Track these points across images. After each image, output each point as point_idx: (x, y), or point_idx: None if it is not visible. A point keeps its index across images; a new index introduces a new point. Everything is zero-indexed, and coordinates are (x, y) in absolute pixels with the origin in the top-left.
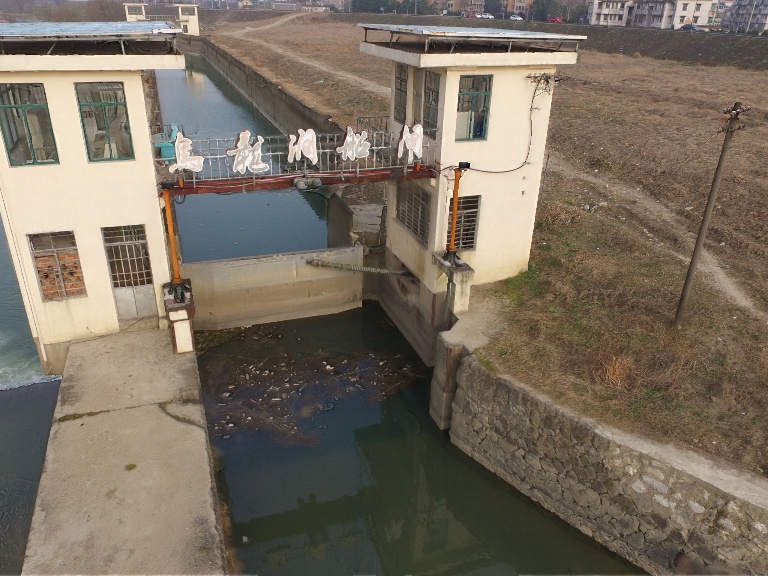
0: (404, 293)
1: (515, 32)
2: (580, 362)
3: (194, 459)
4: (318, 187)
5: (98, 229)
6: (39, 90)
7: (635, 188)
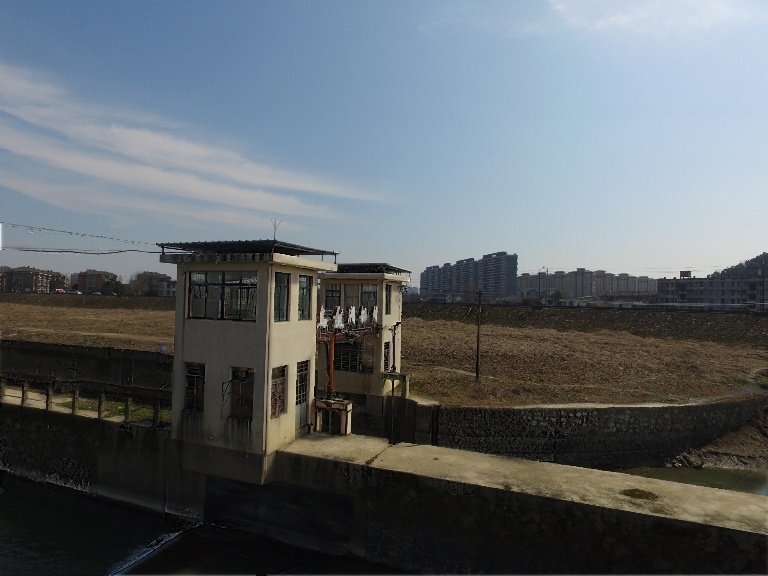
0: None
1: None
2: (476, 396)
3: None
4: None
5: (296, 363)
6: (196, 288)
7: None
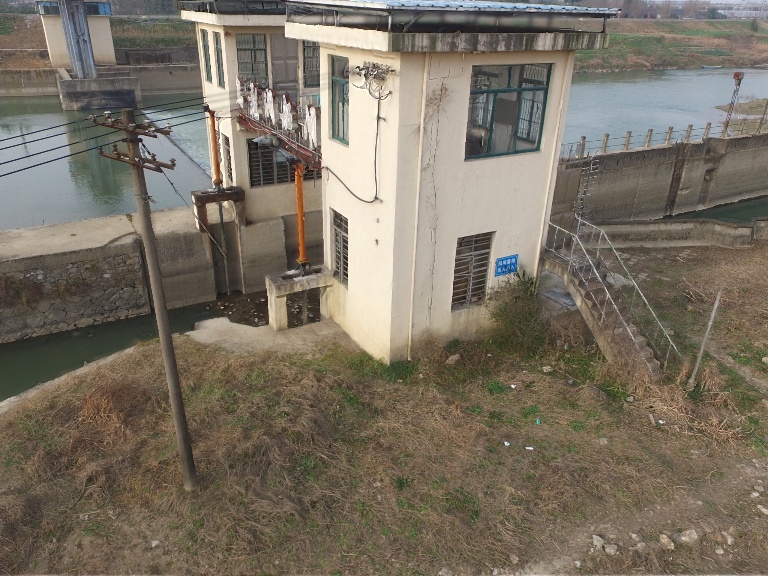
0: None
1: (416, 2)
2: None
3: (72, 247)
4: (276, 147)
5: None
6: None
7: None
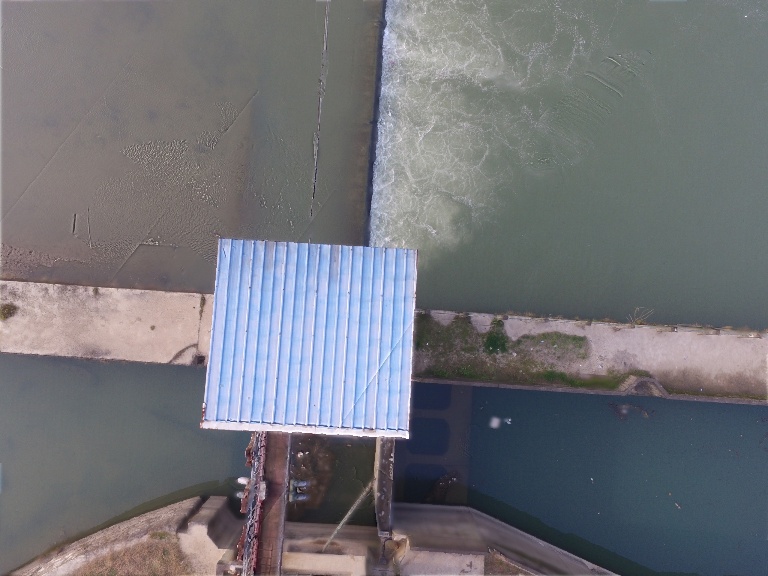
0: (321, 540)
1: None
2: None
3: (147, 355)
4: None
5: None
6: None
7: None
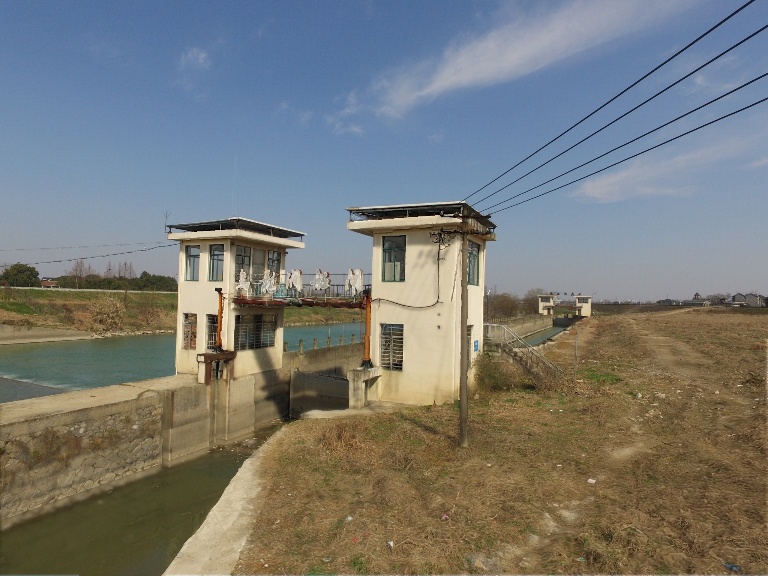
0: None
1: None
2: None
3: (109, 401)
4: (300, 305)
5: (205, 315)
6: None
7: (754, 398)
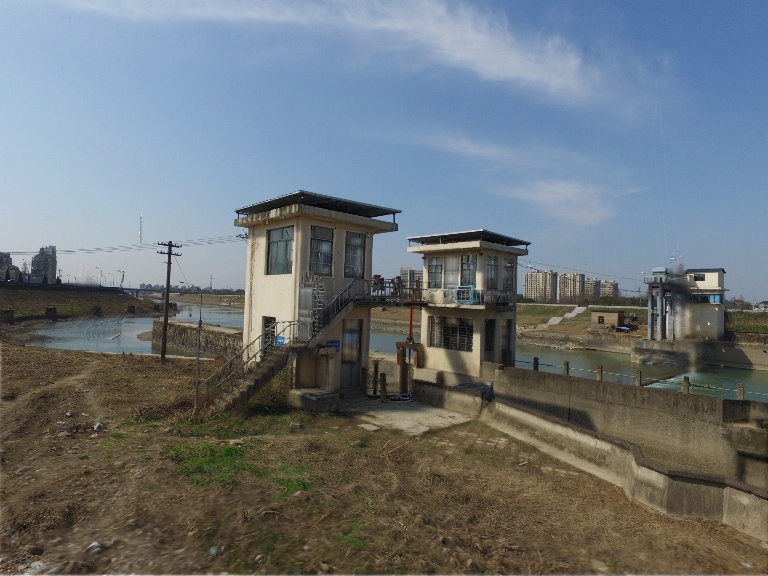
0: None
1: None
2: None
3: None
4: None
5: None
6: None
7: None
